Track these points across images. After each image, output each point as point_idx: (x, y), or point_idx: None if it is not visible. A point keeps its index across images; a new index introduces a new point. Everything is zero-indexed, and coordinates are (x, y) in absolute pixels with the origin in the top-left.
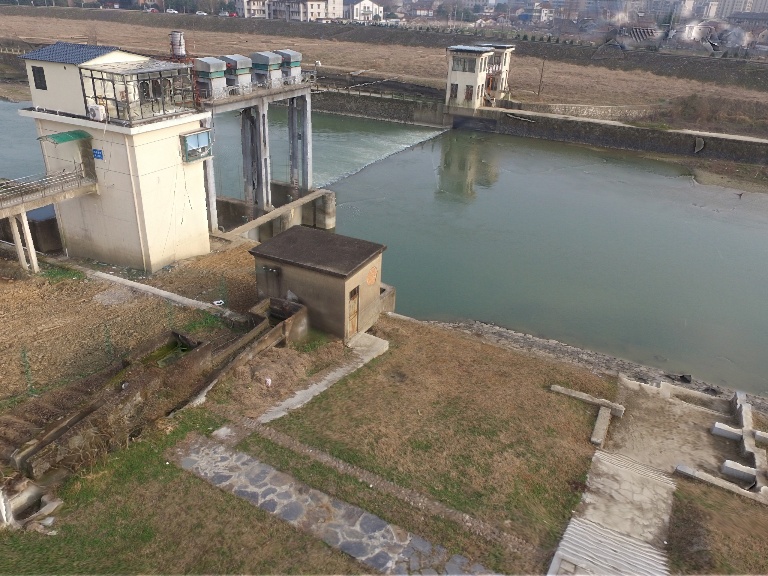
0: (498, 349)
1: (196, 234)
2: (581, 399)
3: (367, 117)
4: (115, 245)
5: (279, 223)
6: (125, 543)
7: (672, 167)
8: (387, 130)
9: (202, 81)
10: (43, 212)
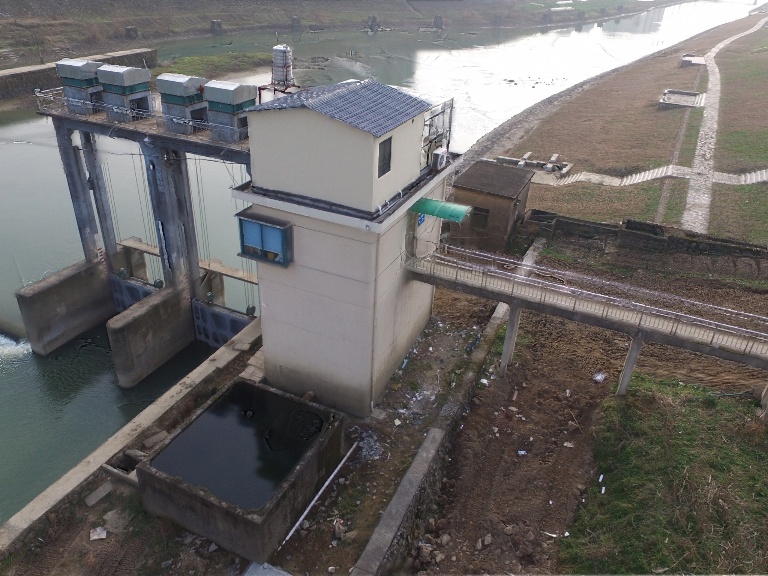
0: None
1: None
2: None
3: None
4: None
5: None
6: (763, 232)
7: (23, 113)
8: None
9: None
10: (226, 466)
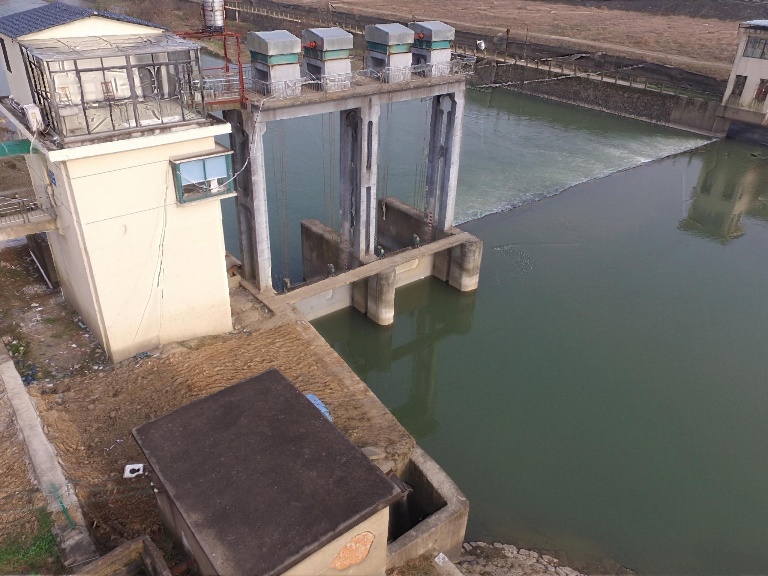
0: None
1: (204, 306)
2: None
3: (606, 110)
4: (86, 306)
5: (375, 283)
6: None
7: None
8: (627, 131)
9: (261, 68)
10: None
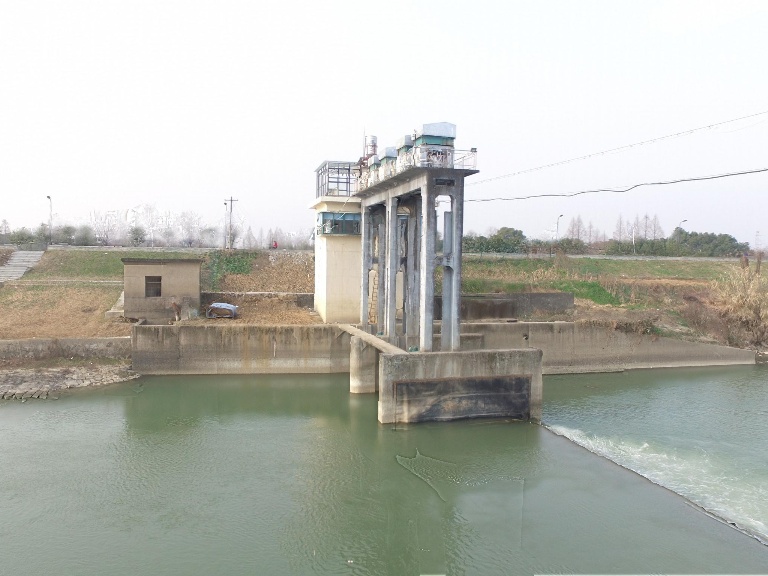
0: (20, 338)
1: None
2: None
3: None
4: None
5: None
6: None
7: None
8: None
9: None
10: None
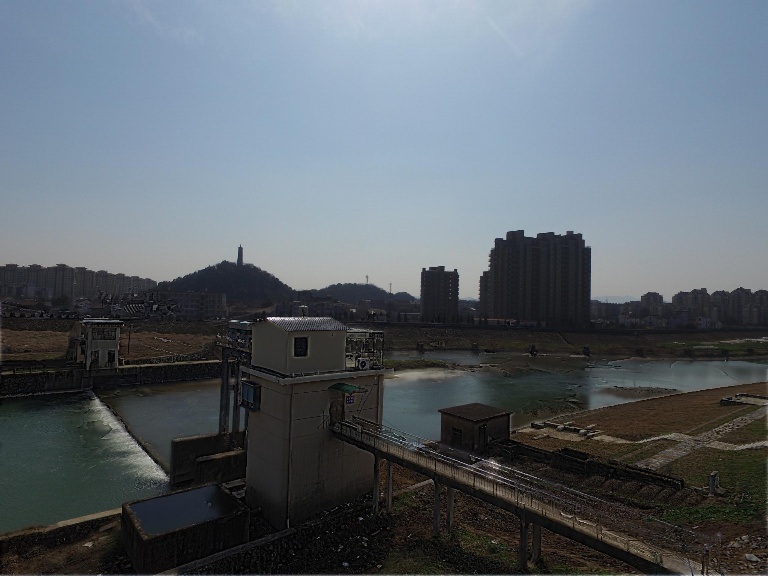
0: None
1: None
2: (543, 437)
3: None
4: (349, 481)
5: None
6: None
7: None
8: (29, 404)
9: None
10: (169, 522)
